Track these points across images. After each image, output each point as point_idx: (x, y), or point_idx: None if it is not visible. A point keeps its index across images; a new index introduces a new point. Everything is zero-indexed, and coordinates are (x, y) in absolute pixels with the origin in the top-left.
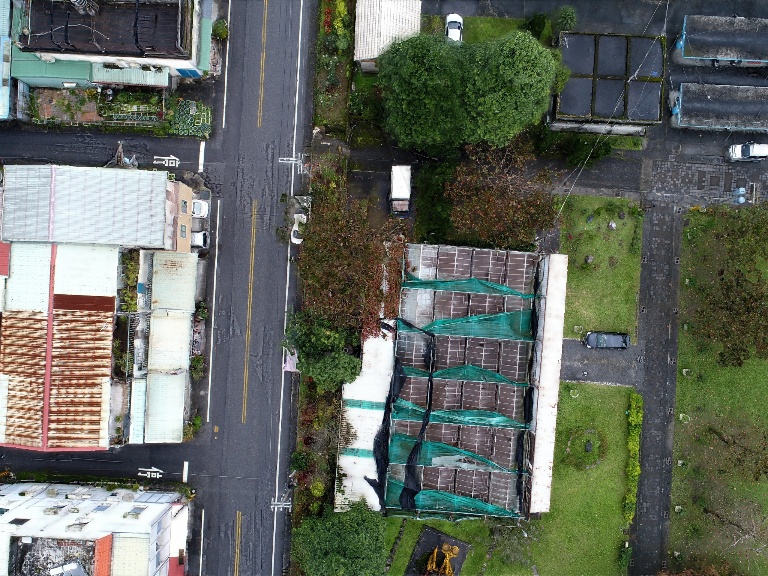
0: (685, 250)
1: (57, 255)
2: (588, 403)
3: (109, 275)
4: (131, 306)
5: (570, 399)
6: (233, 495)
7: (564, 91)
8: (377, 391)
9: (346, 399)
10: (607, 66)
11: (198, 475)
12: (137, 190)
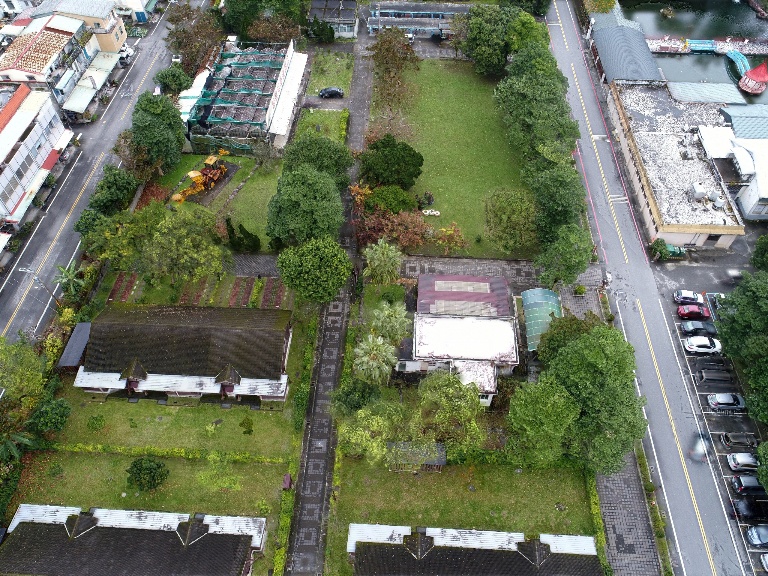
0: (375, 69)
1: (54, 18)
2: (320, 116)
3: (75, 27)
4: (80, 44)
5: (310, 115)
6: (103, 146)
7: (311, 12)
8: (198, 93)
9: (180, 97)
10: (331, 7)
11: (85, 138)
12: (100, 4)
